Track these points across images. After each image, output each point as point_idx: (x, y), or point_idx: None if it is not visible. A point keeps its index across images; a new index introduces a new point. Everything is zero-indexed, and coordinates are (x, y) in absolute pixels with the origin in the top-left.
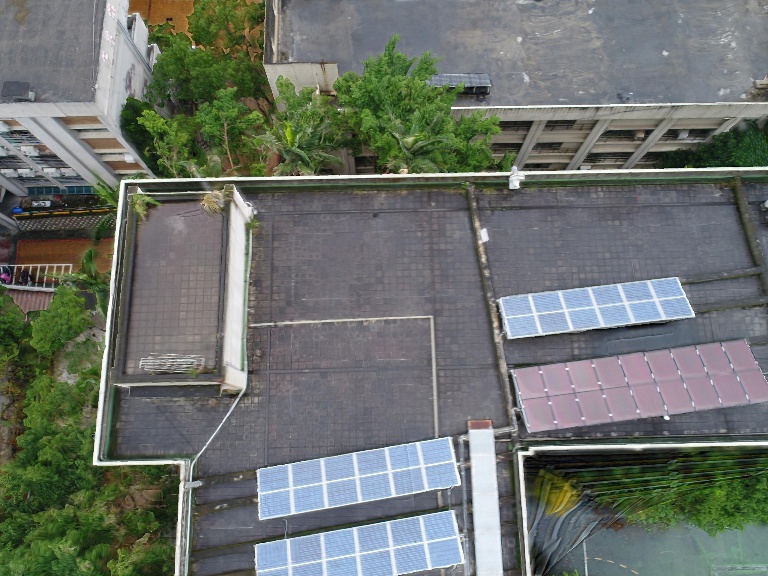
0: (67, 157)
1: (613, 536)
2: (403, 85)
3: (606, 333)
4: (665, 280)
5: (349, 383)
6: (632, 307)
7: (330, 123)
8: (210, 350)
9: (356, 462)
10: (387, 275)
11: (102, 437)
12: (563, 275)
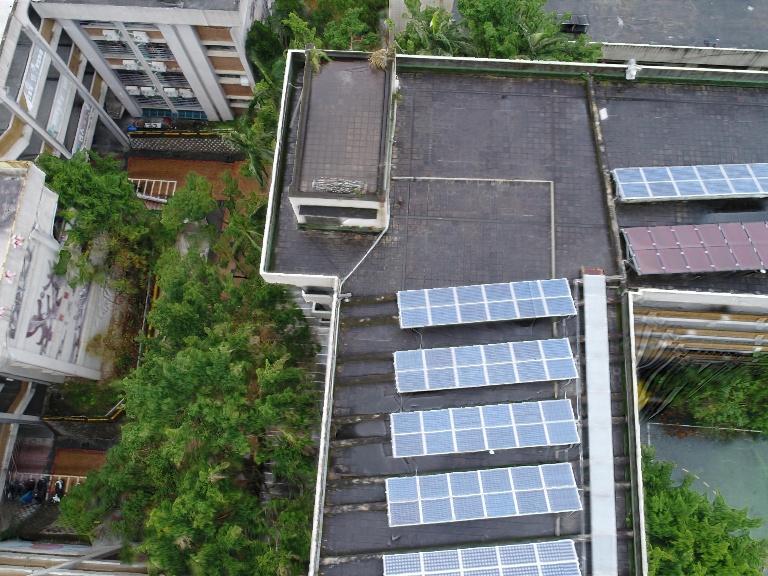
0: (191, 75)
1: (677, 443)
2: (522, 3)
3: (707, 207)
4: (762, 164)
5: (477, 231)
6: (733, 182)
7: (465, 20)
8: (372, 178)
9: (484, 291)
10: (513, 146)
11: (266, 254)
12: (669, 157)
